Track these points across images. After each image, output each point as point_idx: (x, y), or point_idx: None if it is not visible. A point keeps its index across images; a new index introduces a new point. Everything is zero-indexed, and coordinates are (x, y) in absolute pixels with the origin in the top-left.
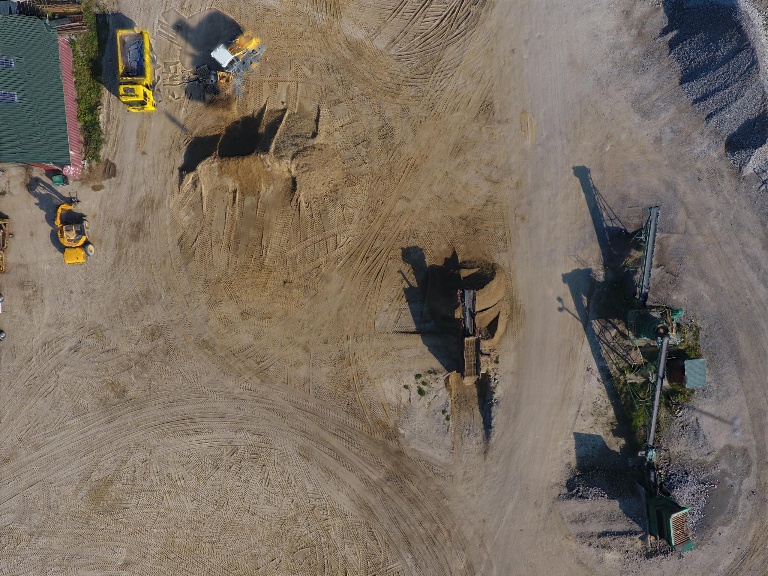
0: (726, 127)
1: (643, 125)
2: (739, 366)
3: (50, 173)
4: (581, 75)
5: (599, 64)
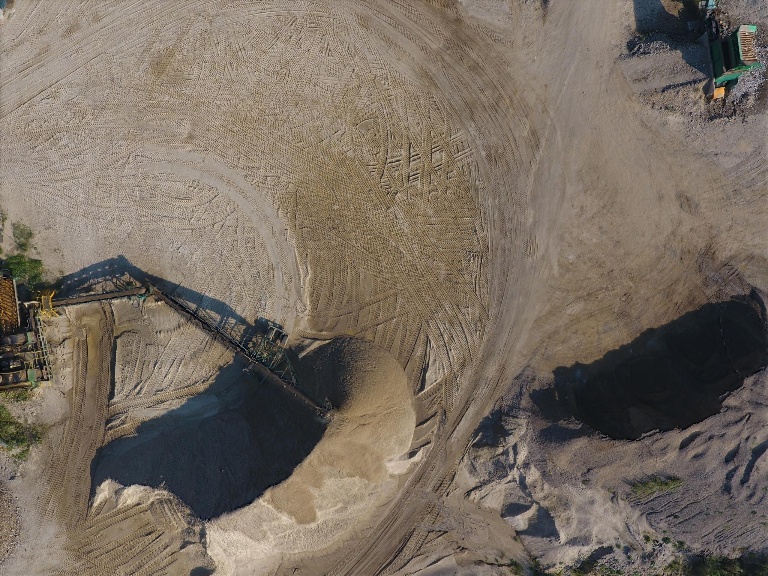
0: None
1: None
2: None
3: None
4: None
5: None
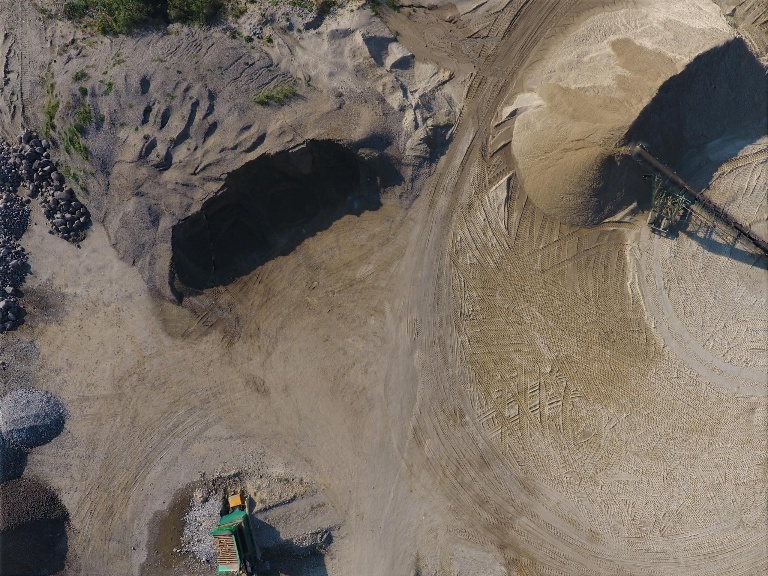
0: None
1: None
2: None
3: None
4: None
5: None
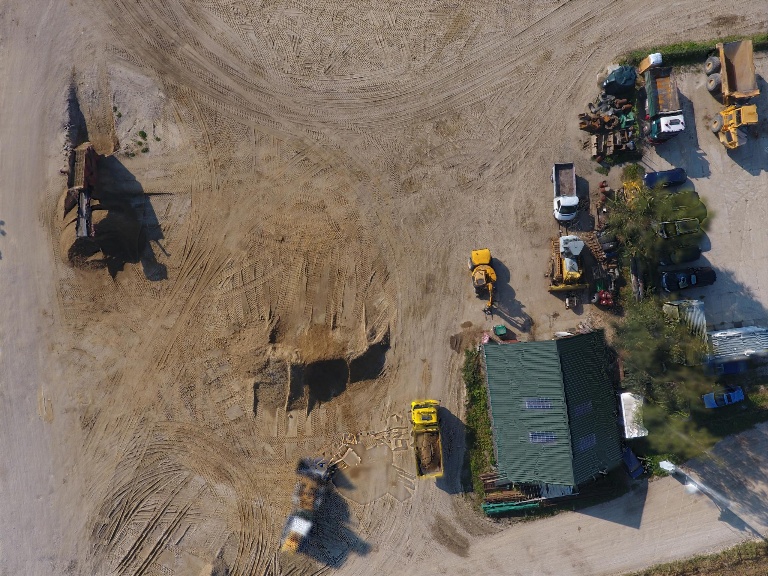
0: None
1: None
2: None
3: (512, 337)
4: None
5: None
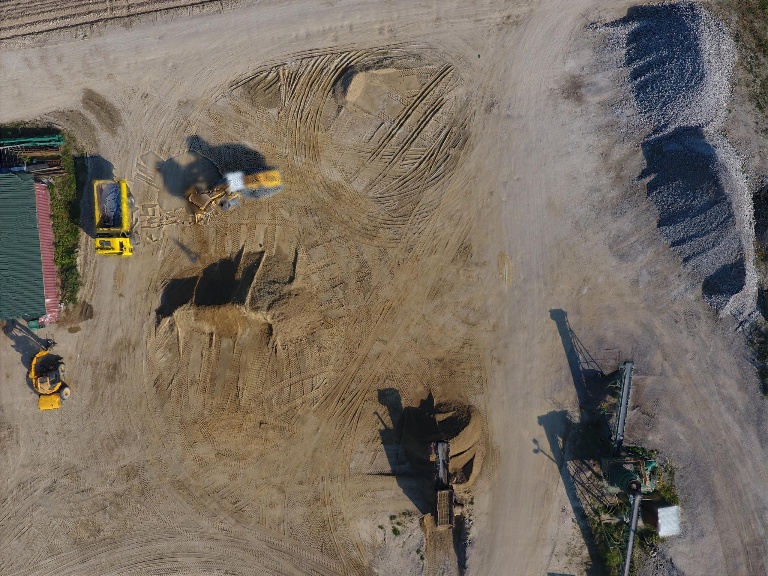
0: (703, 270)
1: (620, 268)
2: (714, 506)
3: (27, 315)
4: (559, 218)
5: (577, 207)
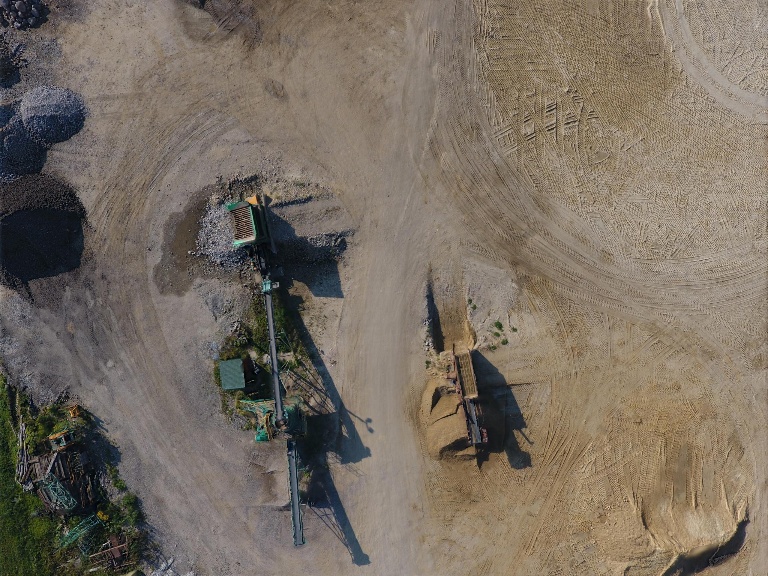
0: None
1: None
2: (177, 378)
3: None
4: None
5: None
